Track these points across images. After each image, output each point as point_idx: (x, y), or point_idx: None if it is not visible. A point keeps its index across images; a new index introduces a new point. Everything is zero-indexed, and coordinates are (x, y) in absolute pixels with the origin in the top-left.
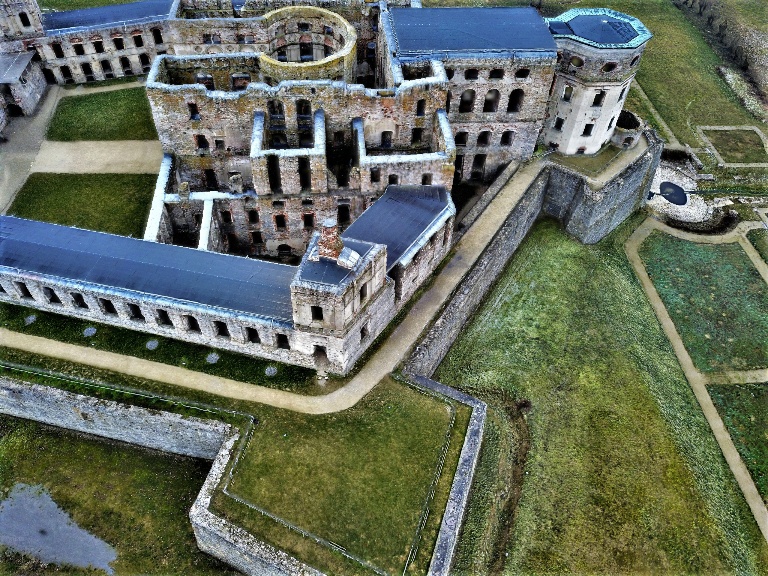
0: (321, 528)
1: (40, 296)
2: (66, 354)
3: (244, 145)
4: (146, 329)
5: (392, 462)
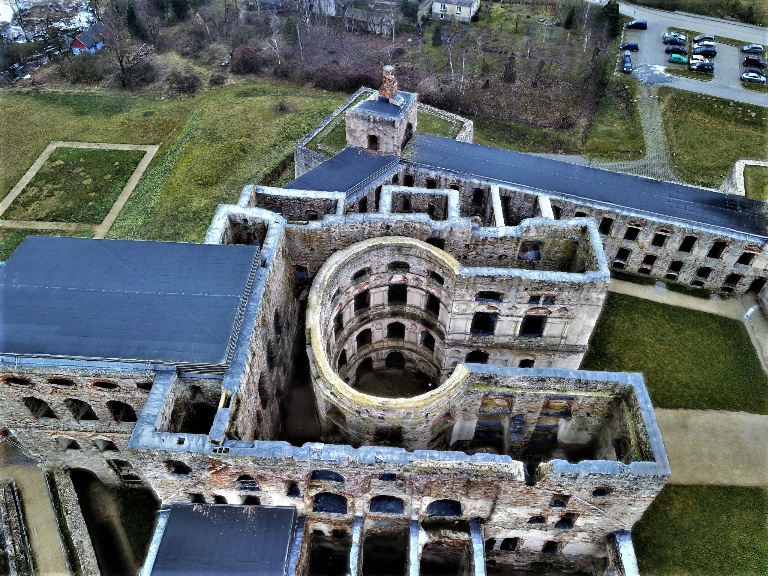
0: None
1: None
2: None
3: None
4: None
5: None
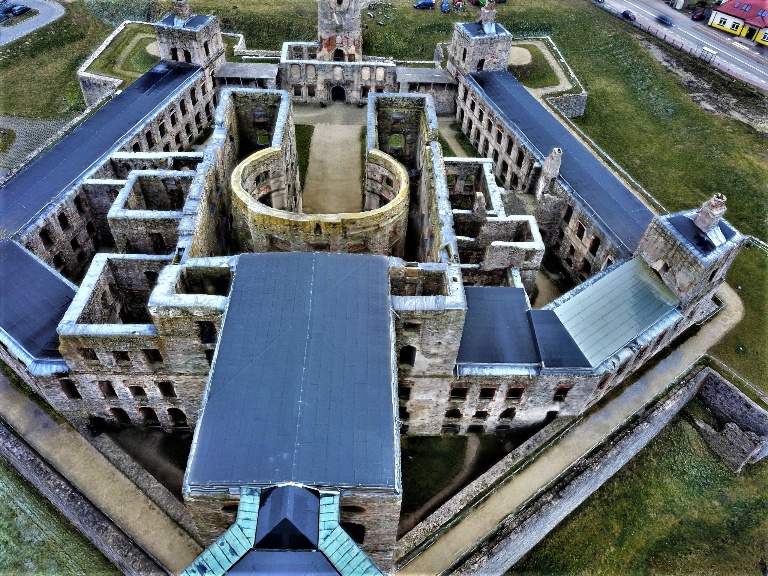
0: None
1: None
2: None
3: None
4: None
5: None
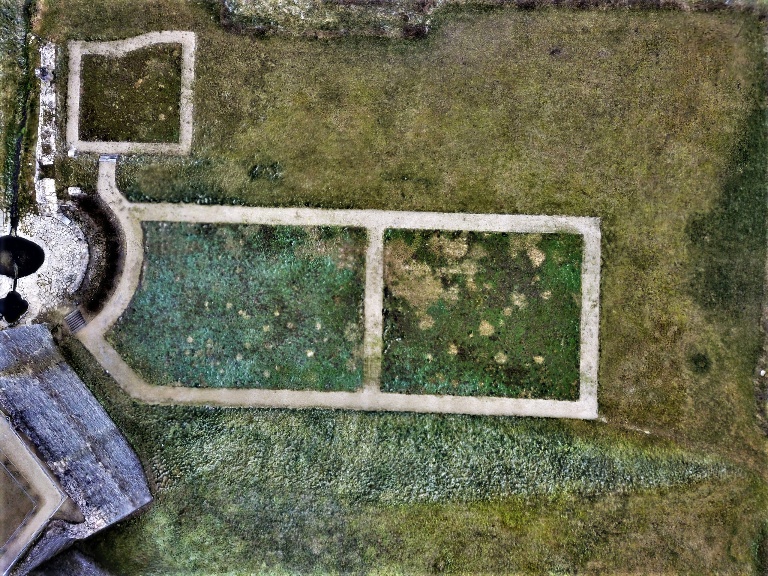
0: None
1: None
2: None
3: None
4: None
5: None
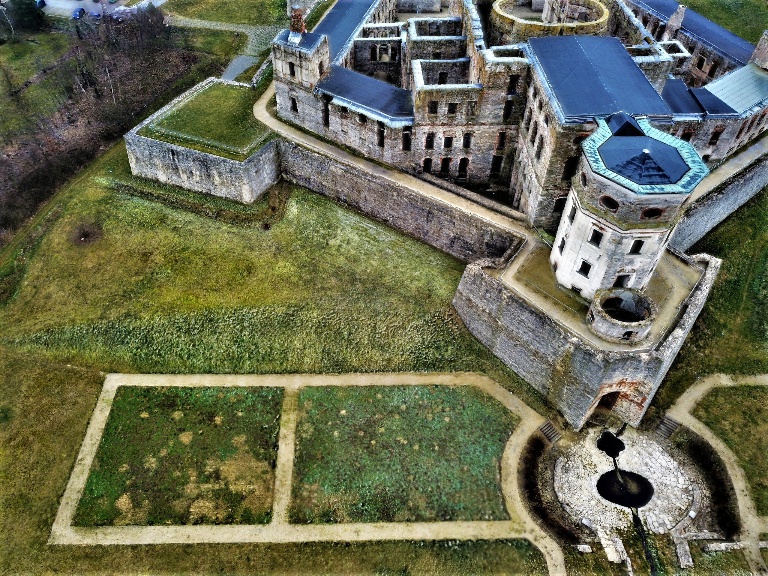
0: (188, 108)
1: None
2: None
3: None
4: None
5: (215, 129)
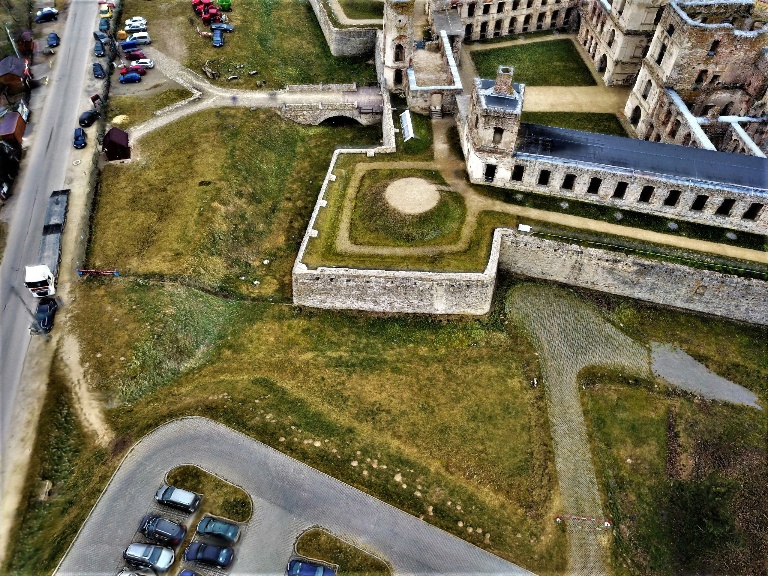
0: None
1: (635, 195)
2: (668, 241)
3: (734, 80)
4: (722, 223)
5: None
